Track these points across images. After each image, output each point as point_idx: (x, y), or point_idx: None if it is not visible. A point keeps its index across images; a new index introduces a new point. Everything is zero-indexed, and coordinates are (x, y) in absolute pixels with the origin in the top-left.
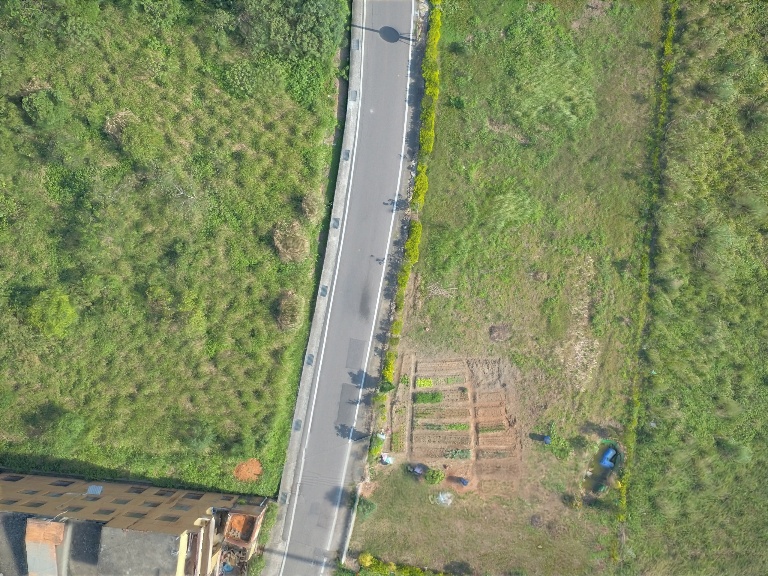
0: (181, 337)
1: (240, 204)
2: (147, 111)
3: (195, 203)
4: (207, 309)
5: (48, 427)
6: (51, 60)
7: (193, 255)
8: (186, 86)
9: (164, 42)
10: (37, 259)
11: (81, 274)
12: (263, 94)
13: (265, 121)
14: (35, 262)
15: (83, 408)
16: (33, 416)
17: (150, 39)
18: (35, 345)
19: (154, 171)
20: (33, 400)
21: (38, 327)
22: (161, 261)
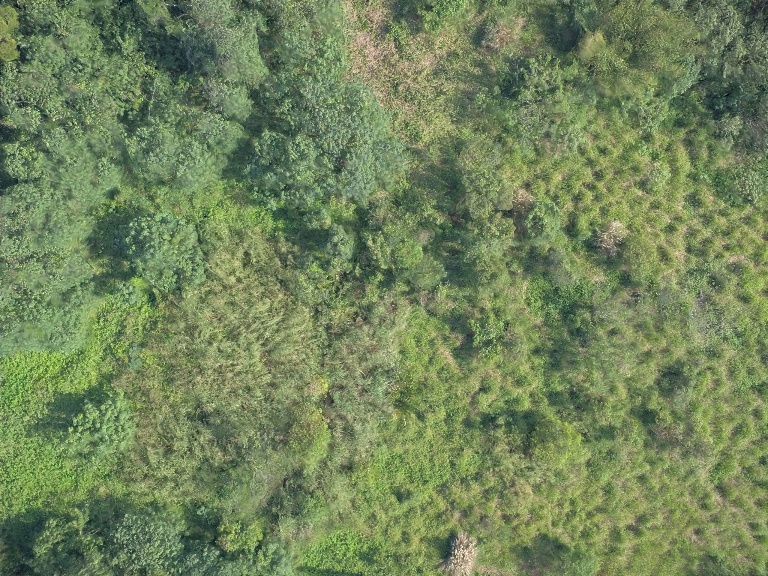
0: (685, 465)
1: (744, 321)
2: (637, 221)
3: (693, 320)
4: (711, 435)
5: (556, 567)
6: (531, 167)
7: (697, 377)
8: (679, 194)
9: (652, 146)
10: (524, 382)
11: (570, 397)
12: (765, 202)
13: (767, 231)
14: (521, 385)
15: (580, 542)
16: (523, 550)
17: (639, 144)
18: (529, 476)
19: (646, 286)
20: (523, 533)
21: (530, 456)
22: (658, 383)
